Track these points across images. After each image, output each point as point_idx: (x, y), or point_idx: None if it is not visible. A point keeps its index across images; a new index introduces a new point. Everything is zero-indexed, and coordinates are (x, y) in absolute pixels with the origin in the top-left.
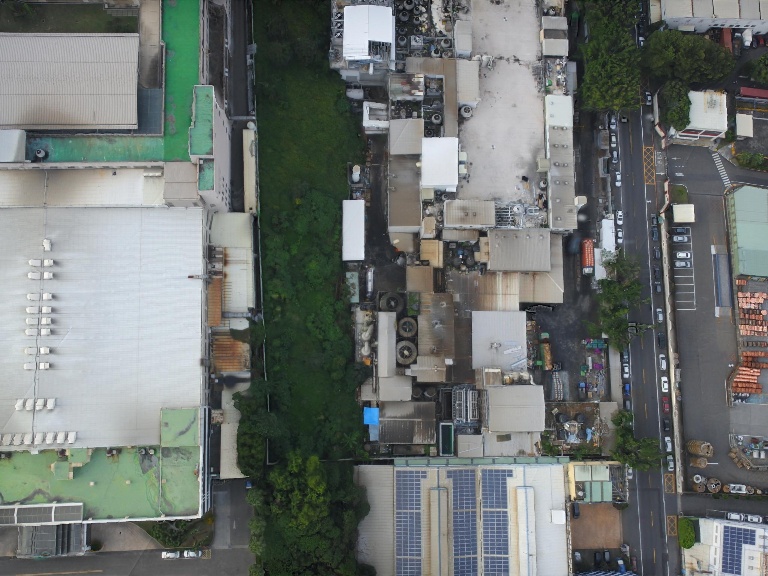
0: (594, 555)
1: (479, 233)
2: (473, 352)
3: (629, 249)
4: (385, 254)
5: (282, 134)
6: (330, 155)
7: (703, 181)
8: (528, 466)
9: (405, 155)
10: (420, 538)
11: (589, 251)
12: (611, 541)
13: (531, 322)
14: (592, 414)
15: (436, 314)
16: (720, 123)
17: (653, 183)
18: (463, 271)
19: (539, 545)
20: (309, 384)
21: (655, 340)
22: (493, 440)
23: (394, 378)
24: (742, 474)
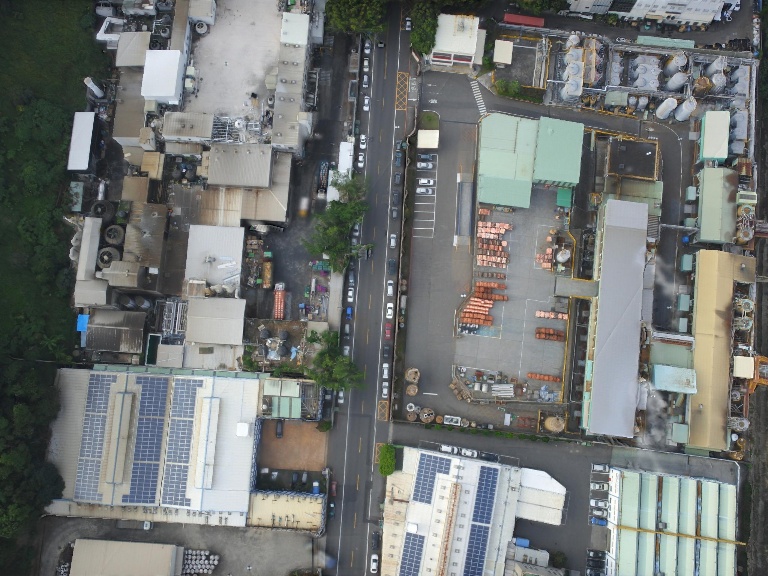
0: (292, 476)
1: (203, 148)
2: (187, 265)
3: (370, 174)
4: (122, 169)
5: (13, 44)
6: (69, 68)
7: (457, 108)
8: (219, 377)
9: (131, 67)
10: (103, 440)
11: (323, 173)
12: (313, 464)
13: (258, 241)
14: (299, 333)
15: (146, 224)
16: (468, 47)
17: (404, 109)
18: (185, 185)
19: (221, 456)
20: (13, 284)
21: (386, 266)
22: (195, 352)
23: (91, 282)
24: (462, 407)
